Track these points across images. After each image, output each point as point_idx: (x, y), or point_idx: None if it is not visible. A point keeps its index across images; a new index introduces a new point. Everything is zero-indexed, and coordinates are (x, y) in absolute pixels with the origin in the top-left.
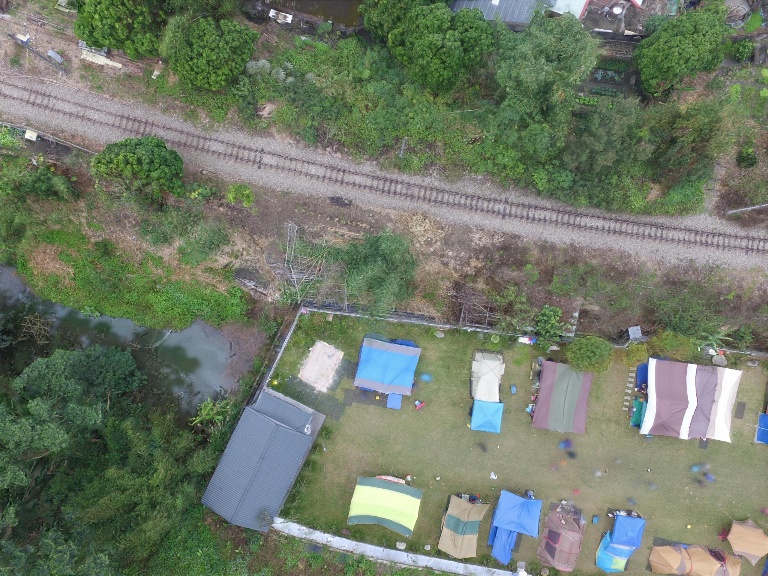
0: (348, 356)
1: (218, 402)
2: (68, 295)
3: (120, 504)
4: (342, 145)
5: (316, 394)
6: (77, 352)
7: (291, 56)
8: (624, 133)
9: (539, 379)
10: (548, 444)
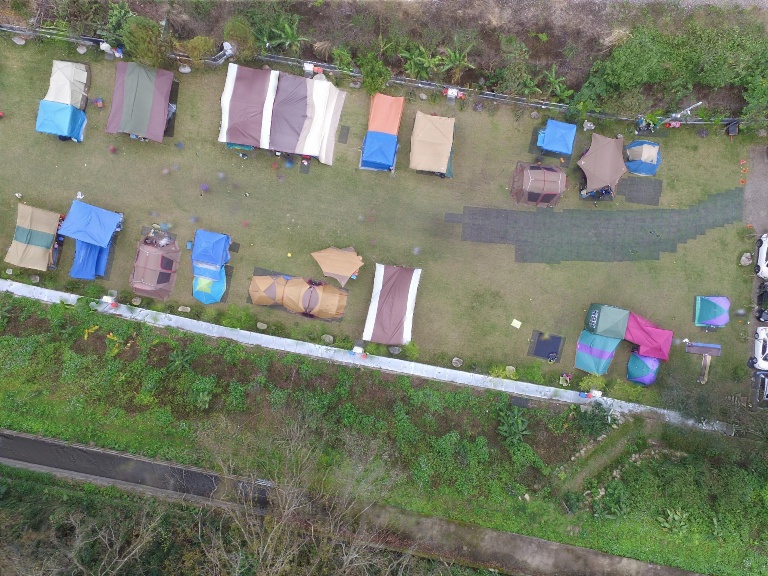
0: None
1: None
2: None
3: None
4: None
5: None
6: None
7: None
8: None
9: None
10: (139, 164)
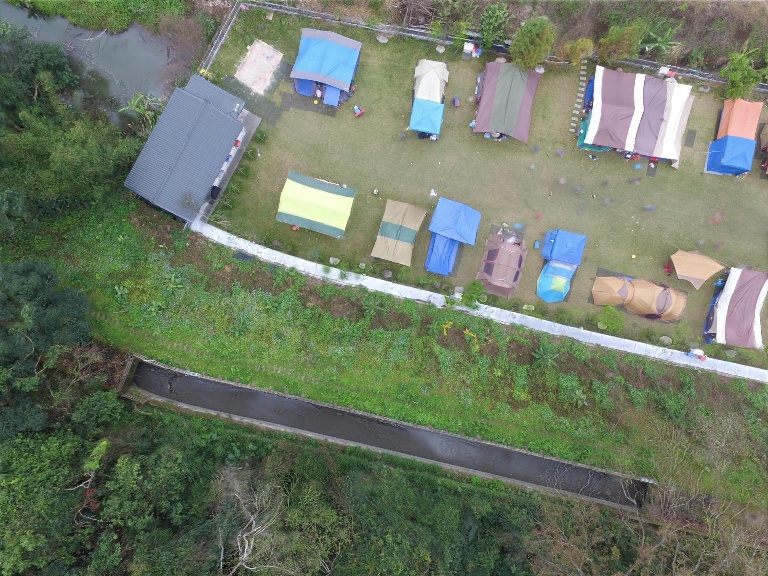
0: (287, 58)
1: (149, 95)
2: None
3: (31, 146)
4: None
5: (252, 96)
6: None
7: None
8: None
9: None
10: (491, 163)
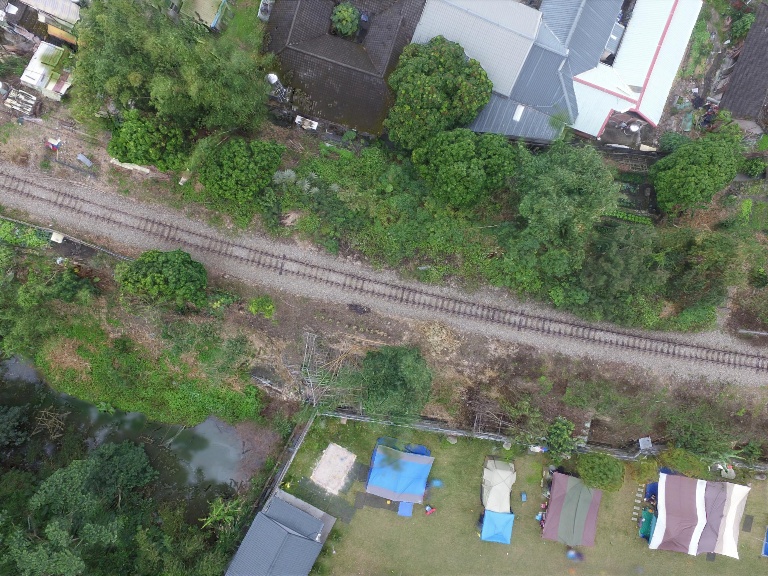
0: (361, 459)
1: (230, 503)
2: (84, 389)
3: None
4: (363, 254)
5: (327, 496)
6: (94, 461)
7: (316, 165)
8: (641, 262)
9: (550, 490)
10: (557, 552)
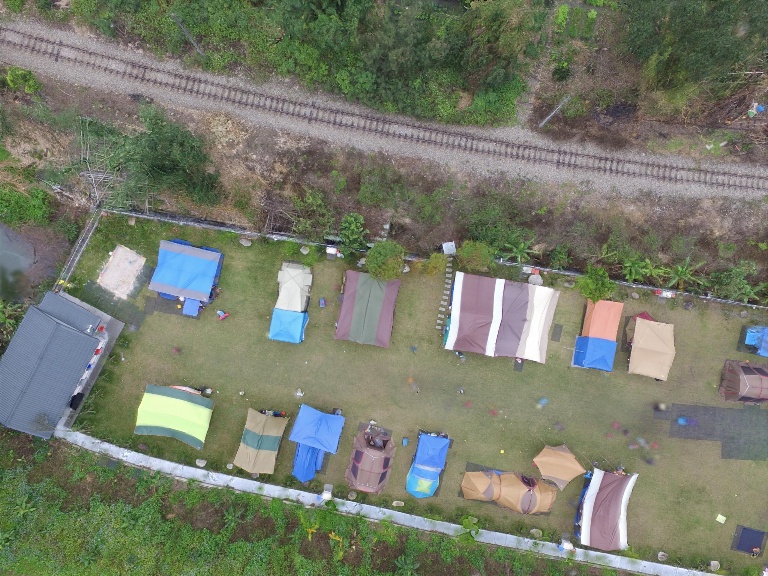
0: (150, 262)
1: (9, 304)
2: None
3: None
4: (144, 41)
5: (116, 301)
6: None
7: None
8: (413, 27)
9: None
10: (358, 361)
